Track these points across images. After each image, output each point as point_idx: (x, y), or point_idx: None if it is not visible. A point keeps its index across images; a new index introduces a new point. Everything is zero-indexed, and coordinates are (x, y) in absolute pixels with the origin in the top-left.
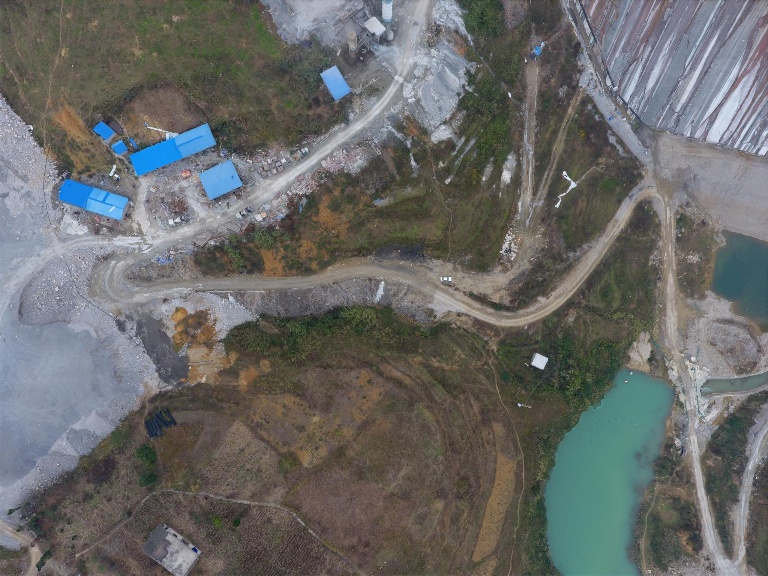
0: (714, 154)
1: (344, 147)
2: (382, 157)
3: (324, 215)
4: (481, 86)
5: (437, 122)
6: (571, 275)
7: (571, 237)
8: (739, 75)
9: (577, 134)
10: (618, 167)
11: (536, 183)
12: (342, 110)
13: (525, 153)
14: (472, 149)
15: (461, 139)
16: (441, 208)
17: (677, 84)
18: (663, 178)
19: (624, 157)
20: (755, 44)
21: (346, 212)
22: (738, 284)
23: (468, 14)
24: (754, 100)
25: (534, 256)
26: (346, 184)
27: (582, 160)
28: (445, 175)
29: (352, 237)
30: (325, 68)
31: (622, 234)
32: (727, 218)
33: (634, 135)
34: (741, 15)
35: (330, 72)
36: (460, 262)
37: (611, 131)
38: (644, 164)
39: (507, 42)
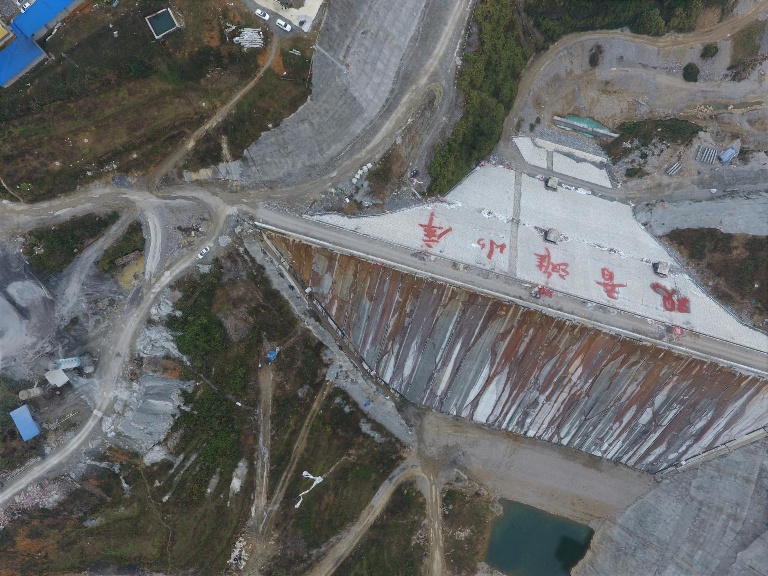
0: (481, 434)
1: (39, 482)
2: (83, 488)
3: (24, 544)
4: (200, 405)
5: (150, 444)
6: (315, 571)
7: (313, 536)
8: (491, 374)
9: (321, 430)
10: (373, 455)
11: (271, 487)
12: (37, 445)
13: (260, 456)
14: (192, 465)
15: (180, 456)
16: (158, 526)
17: (432, 375)
18: (428, 456)
19: (381, 443)
20: (499, 353)
21: (52, 535)
22: (515, 554)
23: (182, 336)
24: (511, 394)
25: (265, 564)
26: (43, 517)
27: (328, 455)
28: (160, 495)
29: (63, 556)
30: (18, 404)
31: (377, 521)
32: (503, 488)
33: (397, 415)
34: (479, 330)
35: (20, 411)
36: (183, 575)
37: (365, 419)
38: (407, 444)
39: (232, 355)
